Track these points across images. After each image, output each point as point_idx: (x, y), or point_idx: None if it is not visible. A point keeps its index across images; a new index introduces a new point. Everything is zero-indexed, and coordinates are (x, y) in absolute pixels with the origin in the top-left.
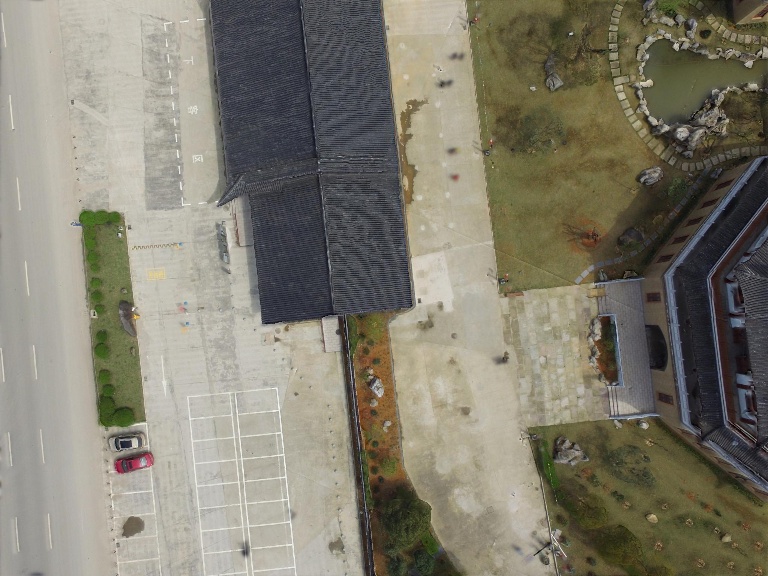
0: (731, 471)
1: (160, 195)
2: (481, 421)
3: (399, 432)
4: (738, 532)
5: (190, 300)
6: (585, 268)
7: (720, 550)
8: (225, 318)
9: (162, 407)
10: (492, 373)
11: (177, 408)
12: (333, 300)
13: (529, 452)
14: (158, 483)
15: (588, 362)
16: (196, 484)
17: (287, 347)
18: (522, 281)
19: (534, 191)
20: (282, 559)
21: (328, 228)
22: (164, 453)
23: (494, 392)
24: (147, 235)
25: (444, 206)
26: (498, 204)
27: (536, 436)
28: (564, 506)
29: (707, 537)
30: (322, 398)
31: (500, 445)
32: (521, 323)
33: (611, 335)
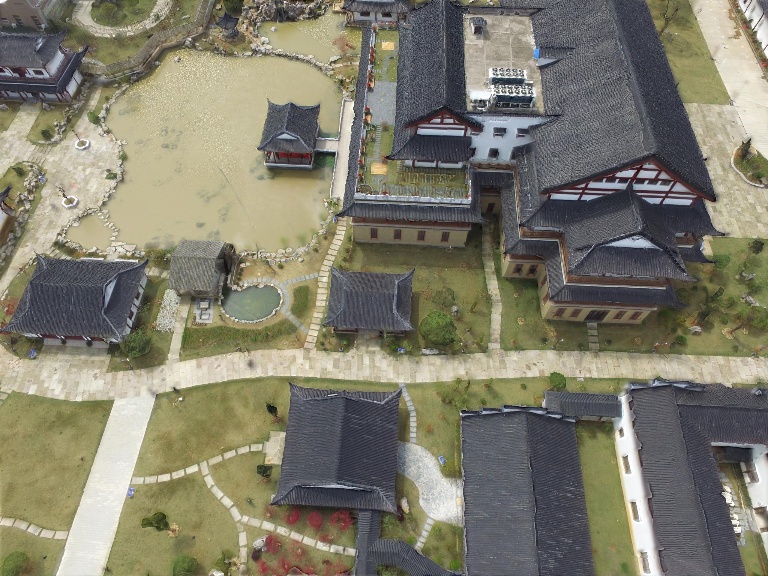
0: None
1: None
2: None
3: None
4: None
5: None
6: None
7: None
8: None
9: None
10: None
11: None
12: None
13: None
14: None
15: None
16: None
17: None
18: None
19: (671, 5)
20: None
21: None
22: None
23: None
24: None
25: (712, 7)
26: (687, 4)
27: None
28: None
29: None
30: None
31: None
32: None
33: None
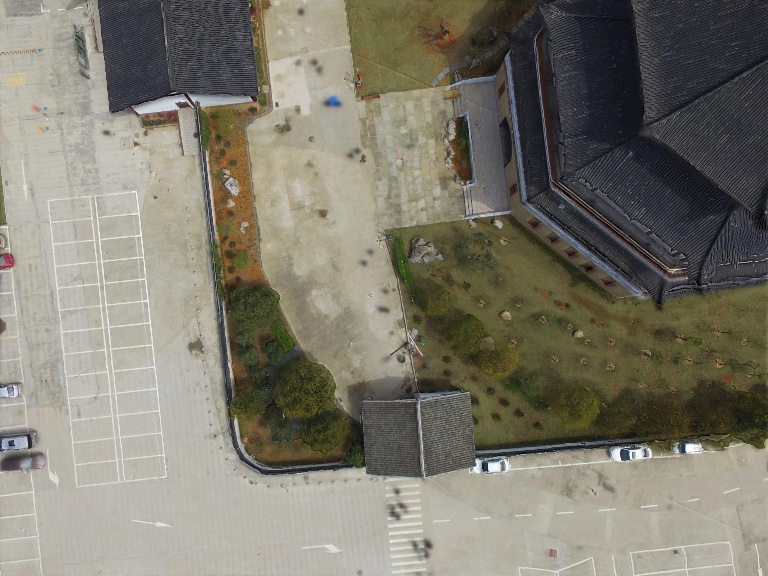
0: (580, 263)
1: (19, 2)
2: (338, 223)
3: (257, 234)
4: (591, 329)
5: (50, 105)
6: (441, 70)
7: (573, 346)
8: (85, 123)
9: (23, 211)
10: (349, 176)
11: (38, 212)
12: (170, 75)
13: (386, 254)
14: (19, 285)
15: (444, 164)
16: (57, 286)
17: (146, 151)
18: (379, 84)
19: None
20: (142, 359)
21: (166, 6)
22: (25, 256)
23: (351, 195)
24: (7, 41)
25: (301, 11)
26: (355, 8)
27: (392, 237)
28: (420, 305)
29: (560, 334)
30: (181, 201)
31: (357, 247)
32: (378, 126)
33: (463, 133)
